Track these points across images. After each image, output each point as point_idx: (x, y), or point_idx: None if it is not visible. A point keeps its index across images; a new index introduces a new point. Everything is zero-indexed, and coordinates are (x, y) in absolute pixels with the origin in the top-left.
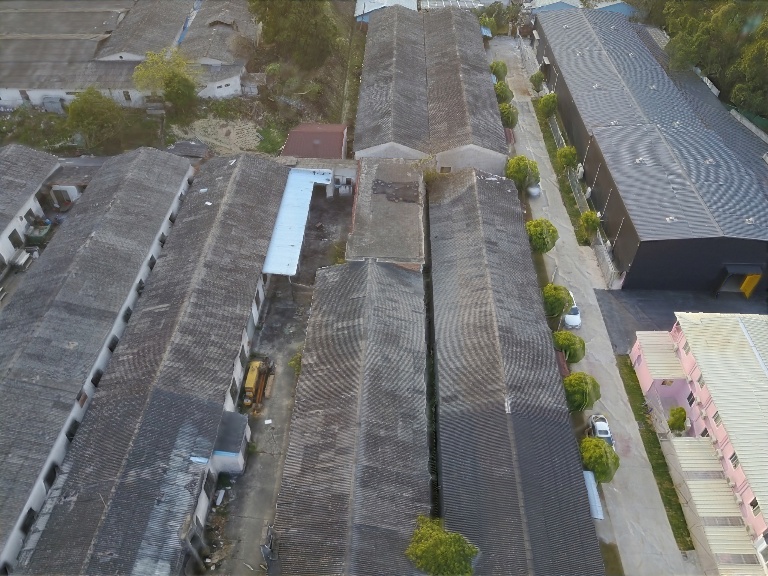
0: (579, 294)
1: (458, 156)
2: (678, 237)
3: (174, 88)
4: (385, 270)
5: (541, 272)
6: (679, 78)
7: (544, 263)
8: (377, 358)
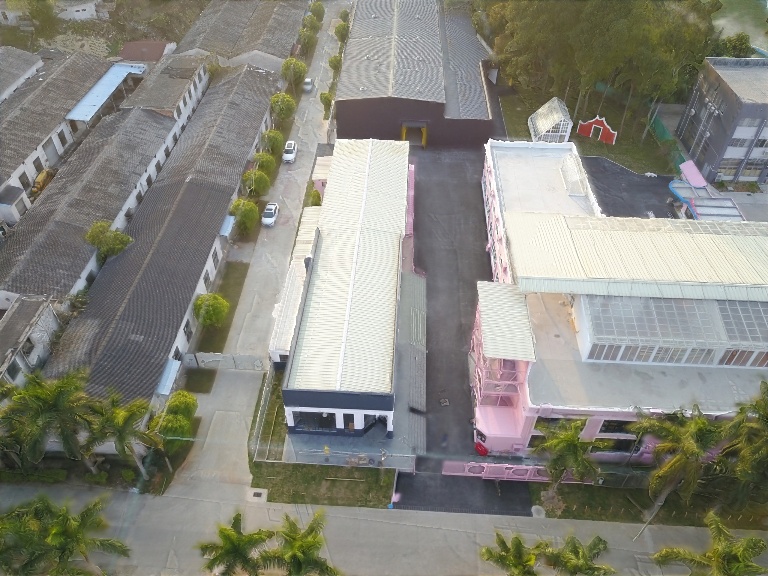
0: (305, 146)
1: (249, 60)
2: (360, 98)
3: (34, 6)
4: (145, 114)
5: (285, 134)
6: (453, 15)
7: (291, 129)
8: (113, 154)
